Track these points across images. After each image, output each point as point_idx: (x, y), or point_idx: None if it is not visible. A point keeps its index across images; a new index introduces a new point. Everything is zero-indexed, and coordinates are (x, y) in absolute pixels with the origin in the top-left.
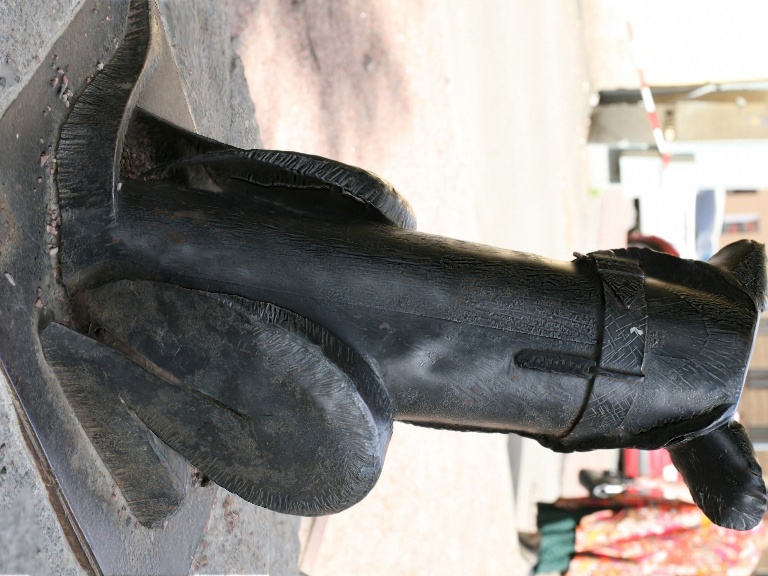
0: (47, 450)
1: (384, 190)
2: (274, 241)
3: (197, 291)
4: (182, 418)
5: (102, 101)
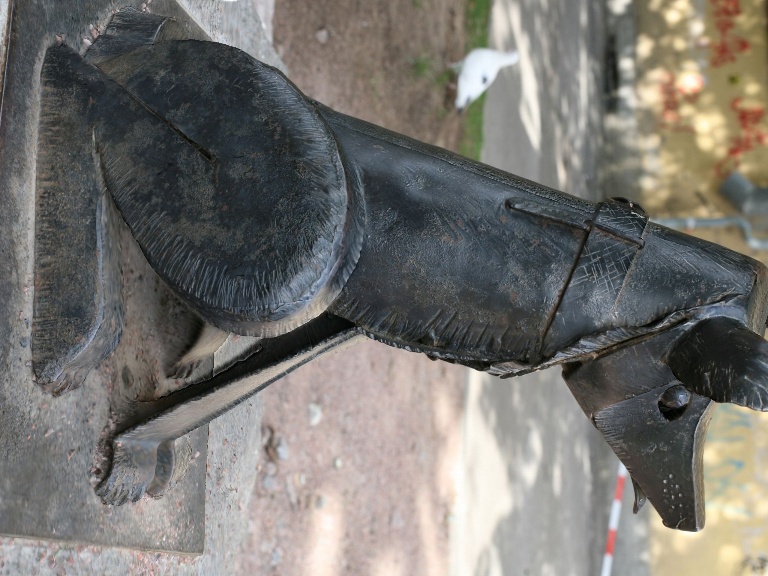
0: (3, 121)
1: None
2: None
3: None
4: (147, 159)
5: None
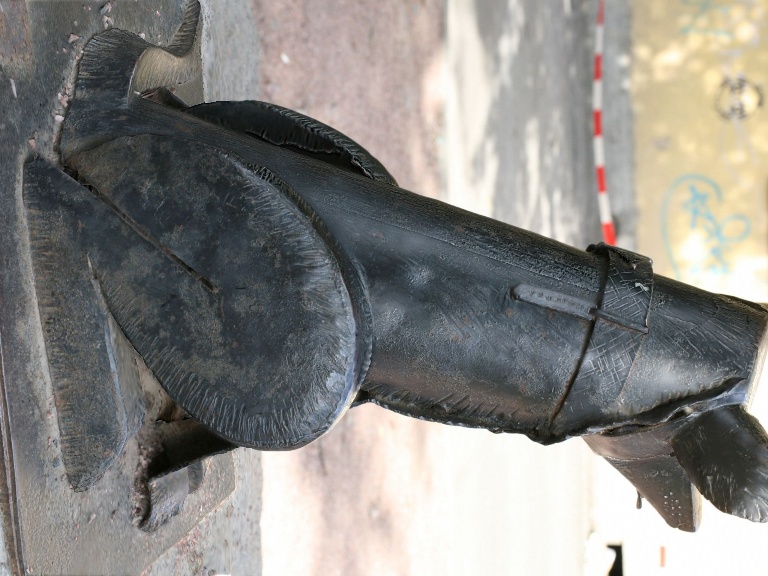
0: None
1: (393, 183)
2: (279, 154)
3: (195, 141)
4: (148, 289)
5: (138, 38)
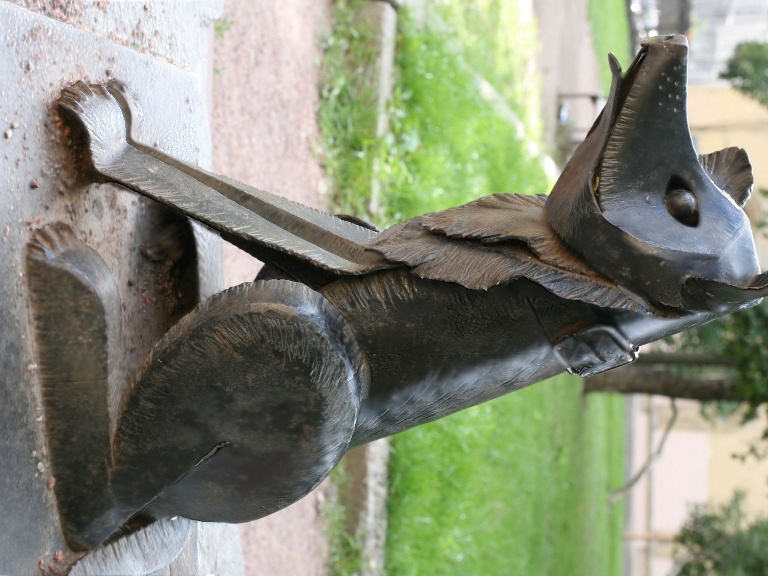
0: None
1: None
2: None
3: None
4: None
5: None
